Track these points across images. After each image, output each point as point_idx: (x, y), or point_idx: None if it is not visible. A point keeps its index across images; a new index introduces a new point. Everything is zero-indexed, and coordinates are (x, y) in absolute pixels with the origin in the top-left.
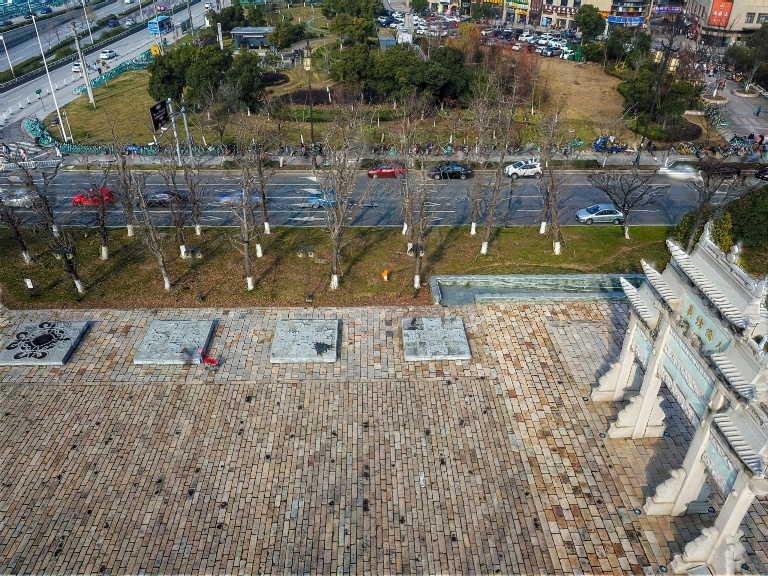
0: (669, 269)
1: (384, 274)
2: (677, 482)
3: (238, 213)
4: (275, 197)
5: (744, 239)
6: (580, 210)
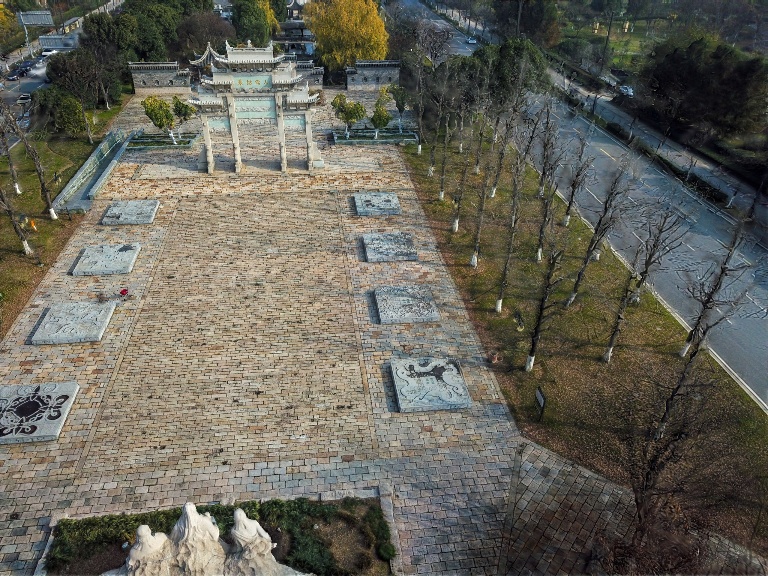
0: (216, 75)
1: (33, 225)
2: None
3: None
4: None
5: None
6: None
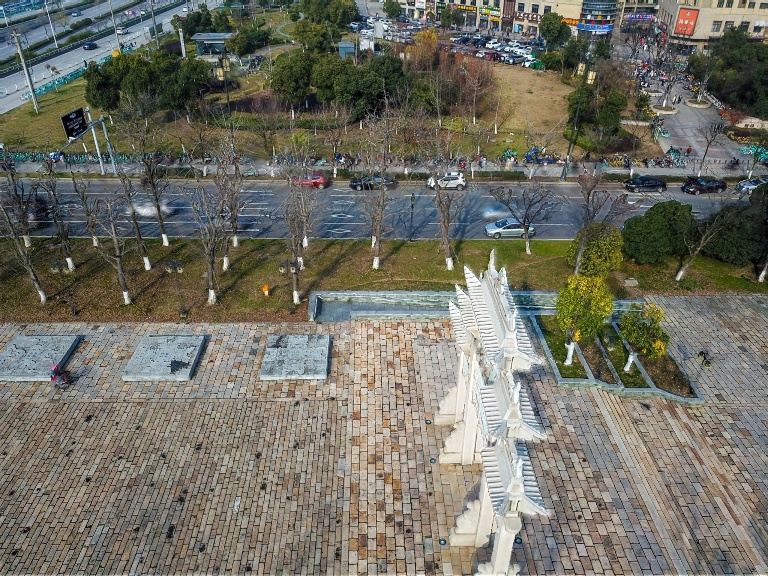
0: None
1: (264, 289)
2: (473, 513)
3: (106, 227)
4: (189, 207)
5: (641, 256)
6: (489, 224)
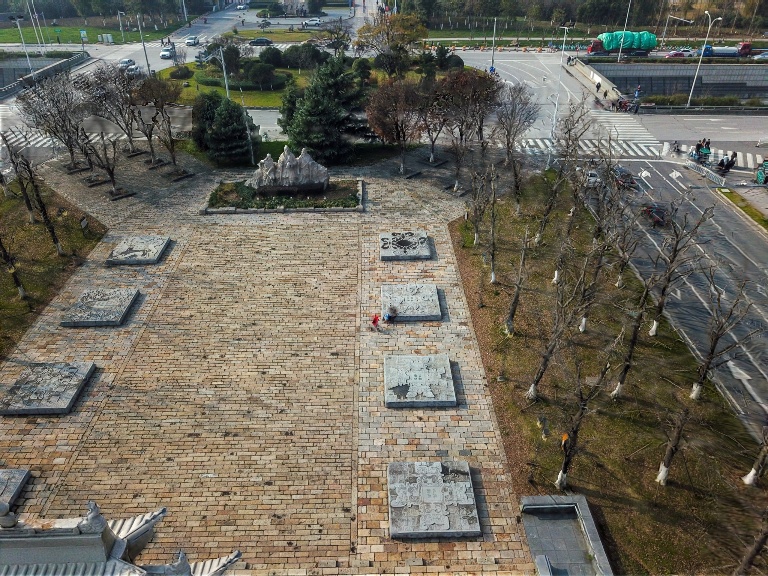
0: None
1: (564, 438)
2: None
3: None
4: None
5: None
6: None
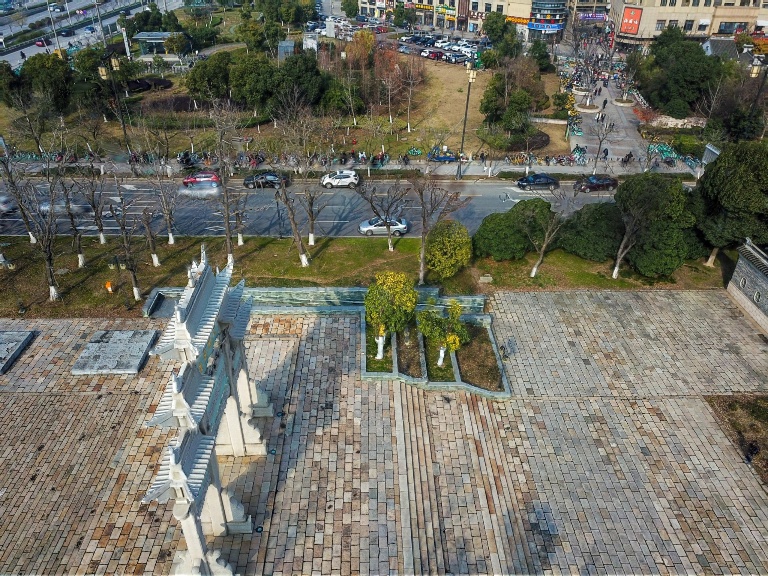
0: None
1: (107, 286)
2: None
3: None
4: (75, 205)
5: (496, 253)
6: (364, 221)
